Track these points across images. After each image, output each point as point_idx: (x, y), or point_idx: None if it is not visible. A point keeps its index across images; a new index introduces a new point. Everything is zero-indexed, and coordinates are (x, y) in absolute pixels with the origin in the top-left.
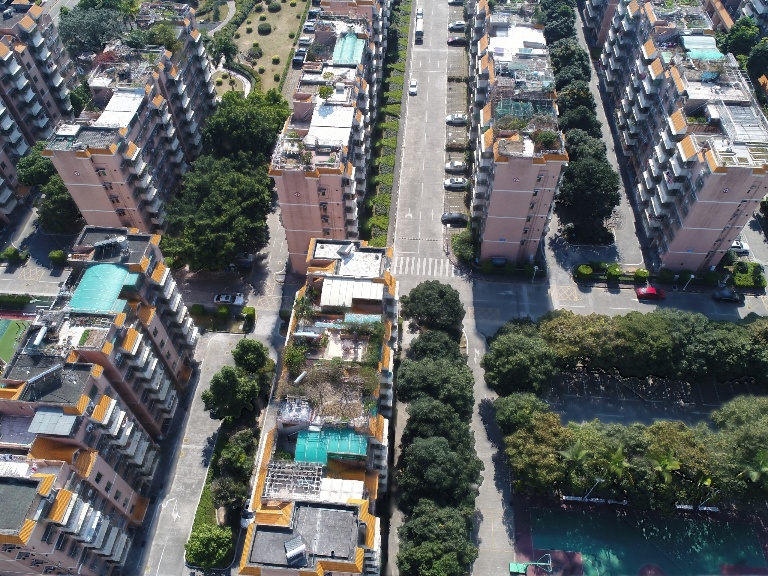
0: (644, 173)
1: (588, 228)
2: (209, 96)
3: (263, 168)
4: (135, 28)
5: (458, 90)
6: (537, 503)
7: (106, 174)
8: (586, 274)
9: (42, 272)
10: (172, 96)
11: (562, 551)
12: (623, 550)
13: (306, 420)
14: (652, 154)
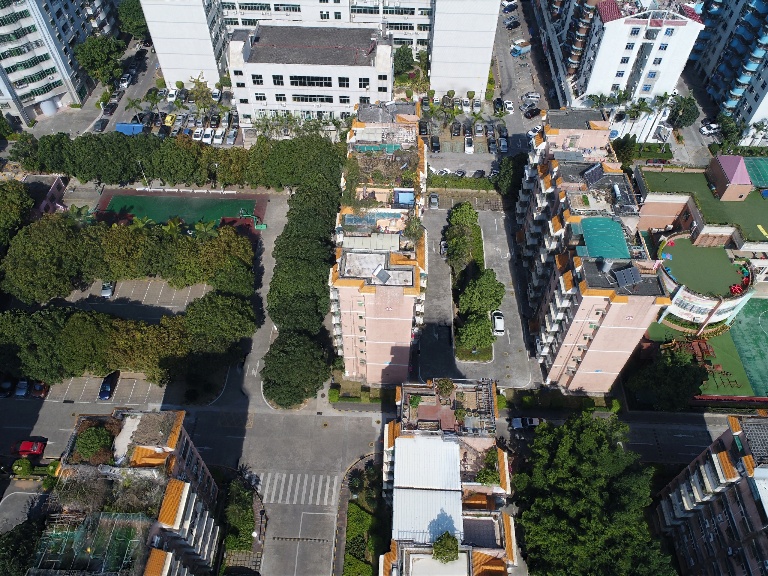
0: None
1: None
2: None
3: None
4: None
5: None
6: None
7: None
8: None
9: None
10: None
11: None
12: None
13: None
14: None
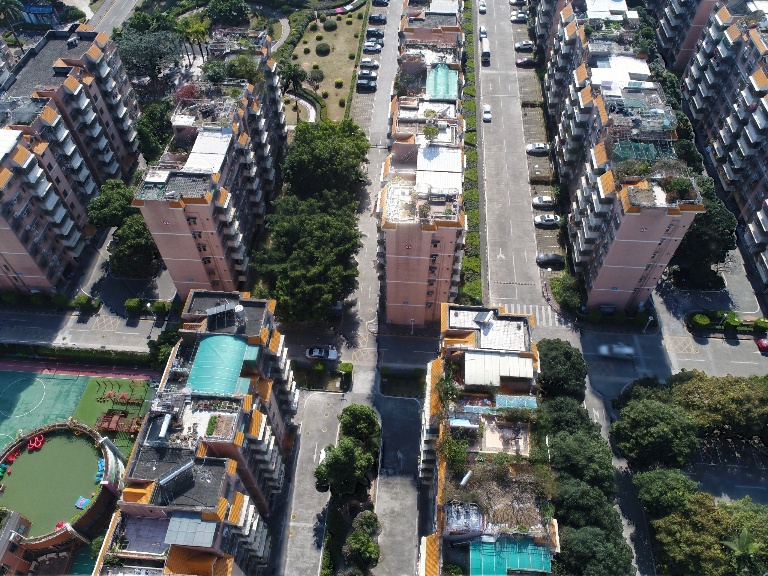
0: (758, 213)
1: (701, 273)
2: (280, 126)
3: (348, 208)
4: (189, 49)
5: (534, 116)
6: None
7: (197, 223)
8: (703, 324)
9: (117, 322)
10: (252, 131)
11: None
12: None
13: (479, 530)
14: (765, 193)
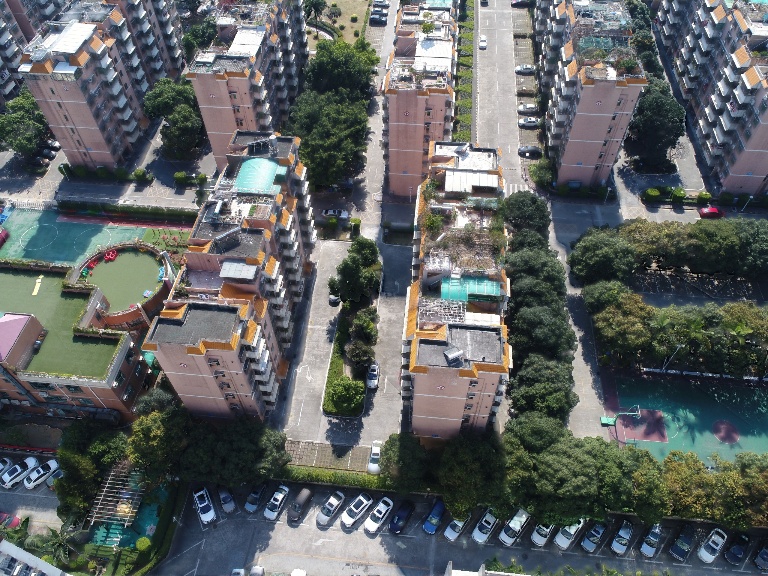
0: (706, 109)
1: (655, 157)
2: (303, 45)
3: (360, 104)
4: None
5: (524, 45)
6: (621, 373)
7: (236, 97)
8: (654, 196)
9: (167, 191)
10: (281, 38)
11: (645, 409)
12: (698, 410)
13: (448, 269)
14: (713, 92)
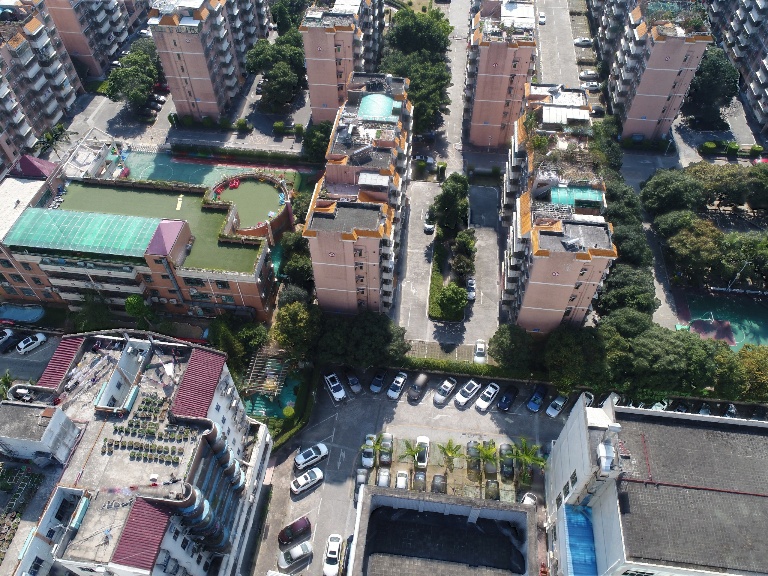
0: (757, 73)
1: (711, 114)
2: (381, 15)
3: (440, 65)
4: None
5: (580, 21)
6: (691, 291)
7: (340, 50)
8: (711, 148)
9: (267, 139)
10: None
11: (714, 320)
12: (762, 321)
13: (557, 179)
14: (763, 58)
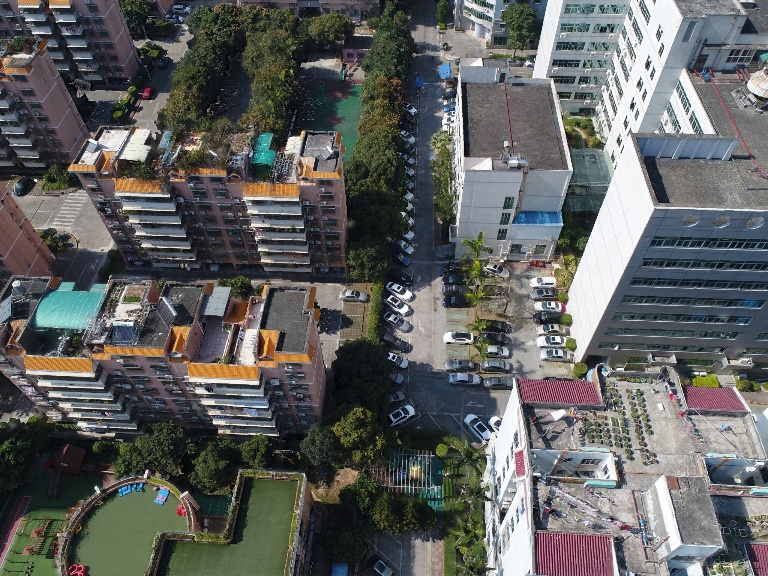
0: None
1: (81, 101)
2: None
3: None
4: None
5: None
6: None
7: None
8: (122, 114)
9: None
10: None
11: None
12: (319, 128)
13: None
14: None
